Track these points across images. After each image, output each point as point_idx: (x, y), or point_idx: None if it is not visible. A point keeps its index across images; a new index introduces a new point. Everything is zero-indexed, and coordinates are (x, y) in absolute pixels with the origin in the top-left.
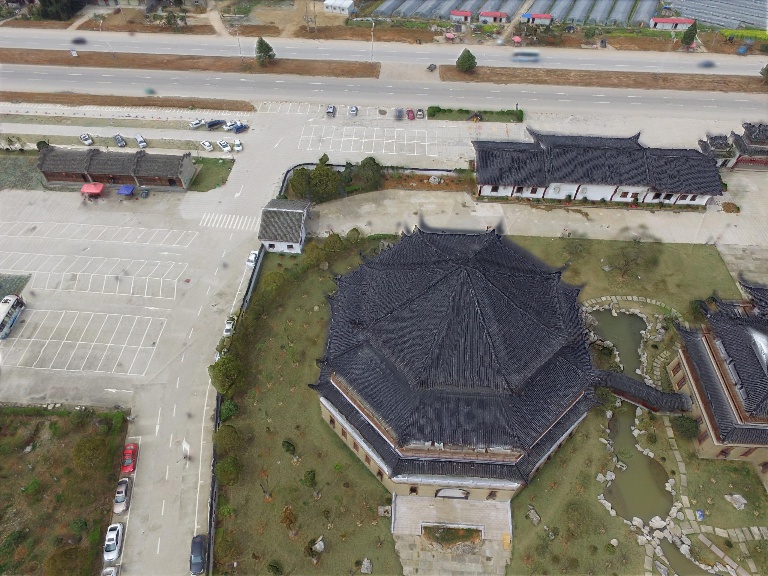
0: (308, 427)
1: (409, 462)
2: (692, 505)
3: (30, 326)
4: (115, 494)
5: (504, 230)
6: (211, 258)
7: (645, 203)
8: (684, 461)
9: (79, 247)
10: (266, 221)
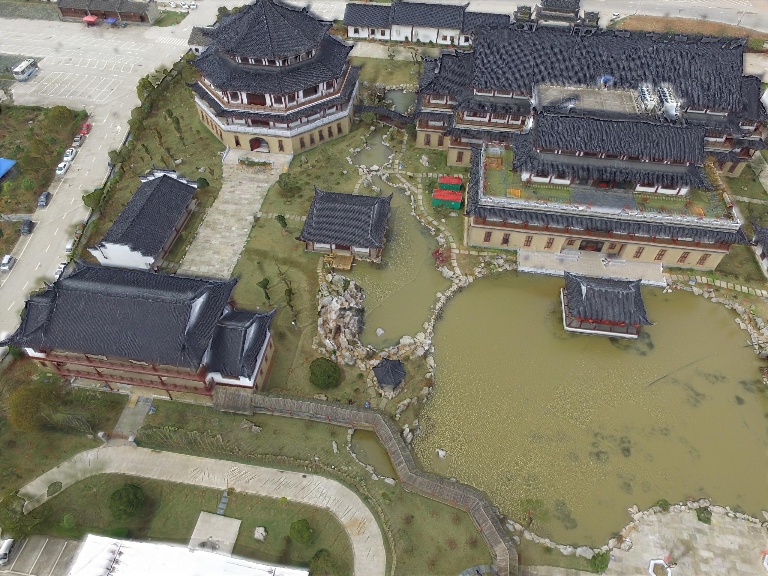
0: (191, 124)
1: (229, 112)
2: (399, 163)
3: (40, 78)
4: (74, 138)
5: (356, 54)
6: (158, 57)
7: (460, 45)
8: (406, 148)
9: (76, 47)
10: (194, 33)
